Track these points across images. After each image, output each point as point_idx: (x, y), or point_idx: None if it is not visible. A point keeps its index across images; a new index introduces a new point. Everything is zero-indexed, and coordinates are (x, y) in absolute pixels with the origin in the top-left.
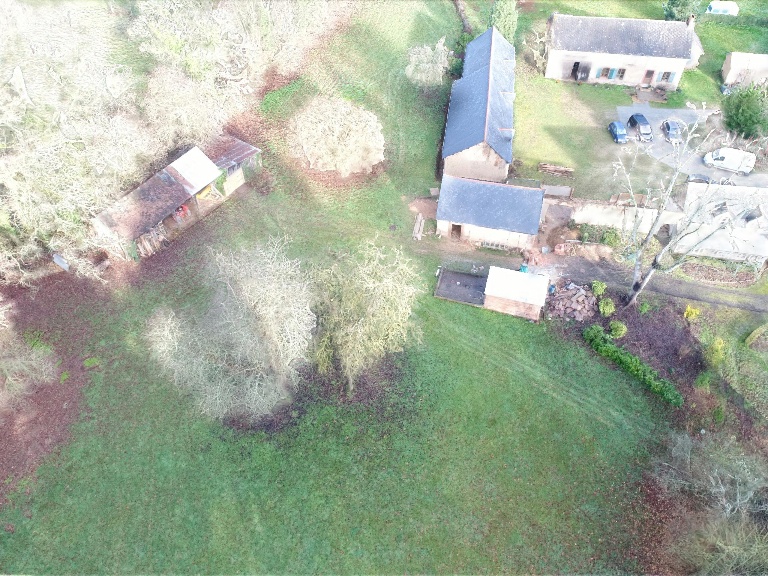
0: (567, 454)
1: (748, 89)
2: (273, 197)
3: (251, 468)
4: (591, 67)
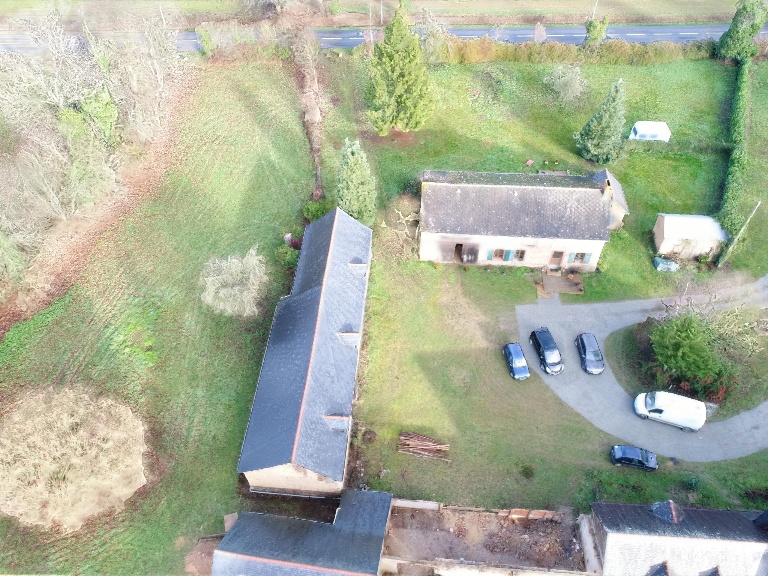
0: None
1: (688, 329)
2: None
3: None
4: (479, 249)
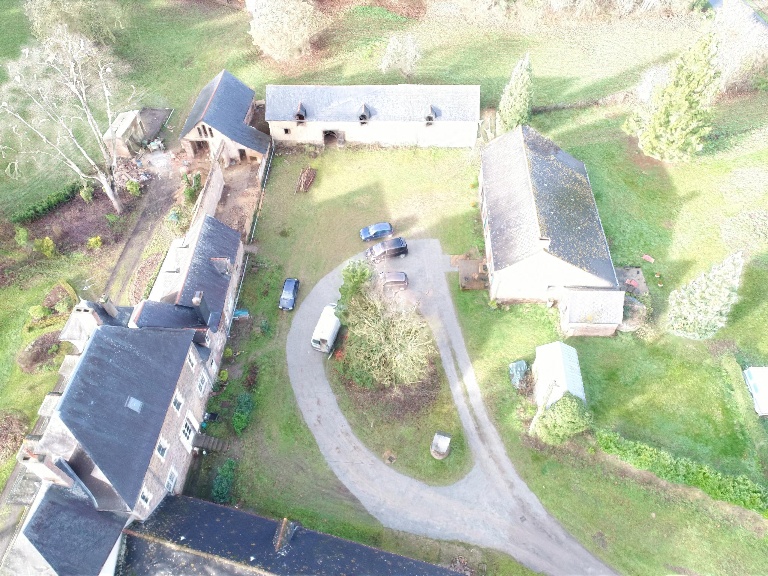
0: (1, 168)
1: None
2: (248, 28)
3: None
4: None
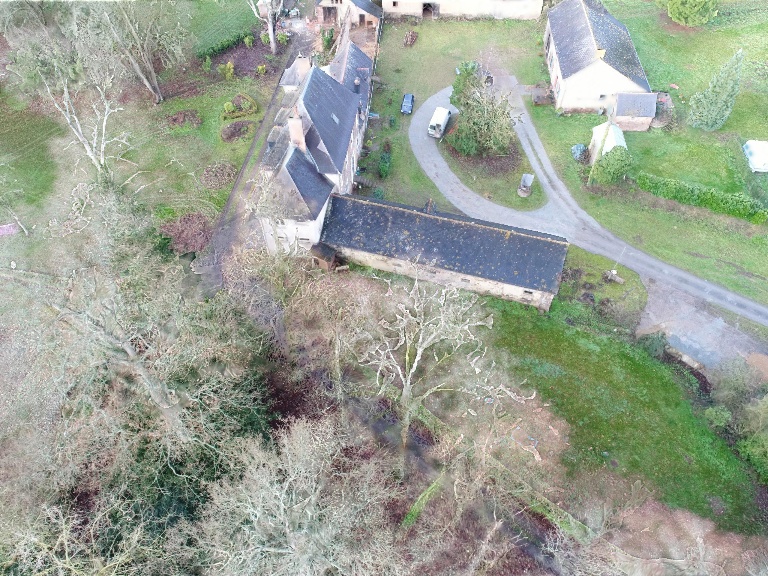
0: None
1: None
2: None
3: None
4: (550, 46)
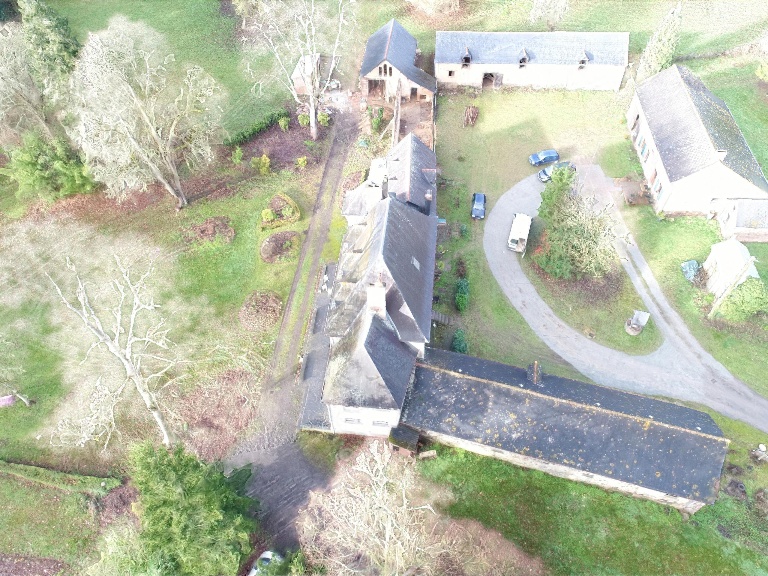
0: (200, 103)
1: None
2: None
3: (201, 7)
4: None
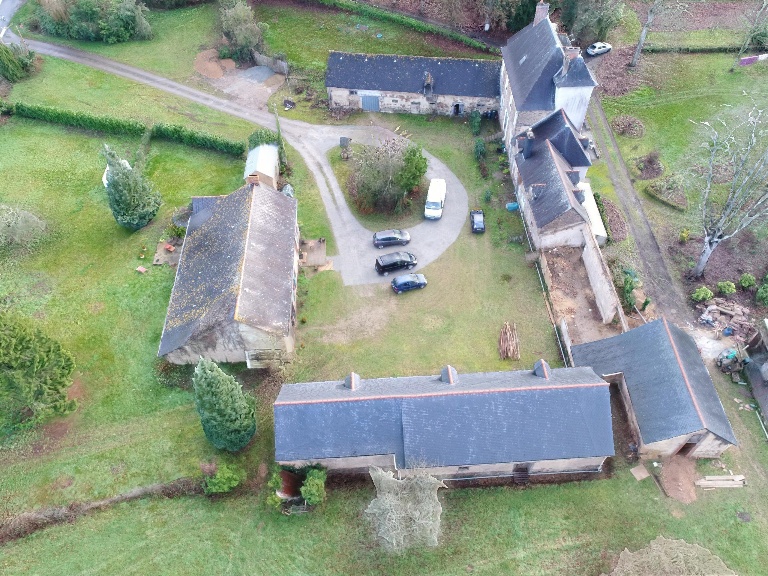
0: None
1: (415, 149)
2: None
3: None
4: None
